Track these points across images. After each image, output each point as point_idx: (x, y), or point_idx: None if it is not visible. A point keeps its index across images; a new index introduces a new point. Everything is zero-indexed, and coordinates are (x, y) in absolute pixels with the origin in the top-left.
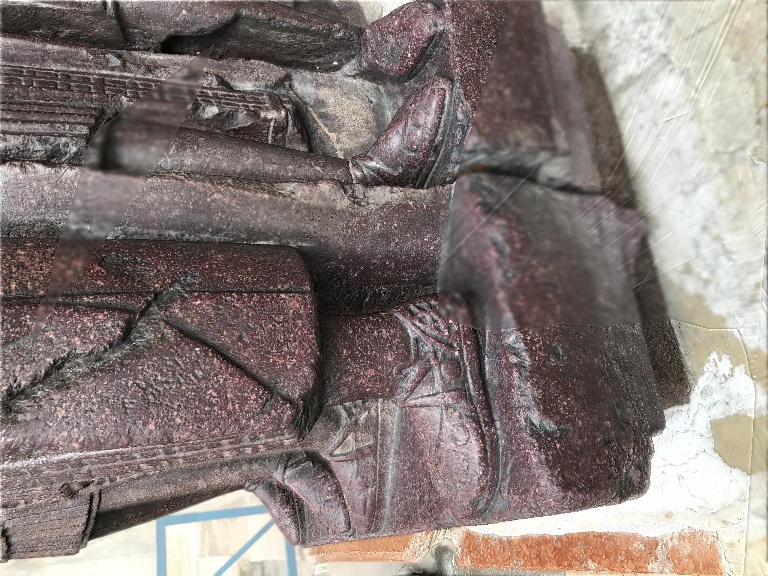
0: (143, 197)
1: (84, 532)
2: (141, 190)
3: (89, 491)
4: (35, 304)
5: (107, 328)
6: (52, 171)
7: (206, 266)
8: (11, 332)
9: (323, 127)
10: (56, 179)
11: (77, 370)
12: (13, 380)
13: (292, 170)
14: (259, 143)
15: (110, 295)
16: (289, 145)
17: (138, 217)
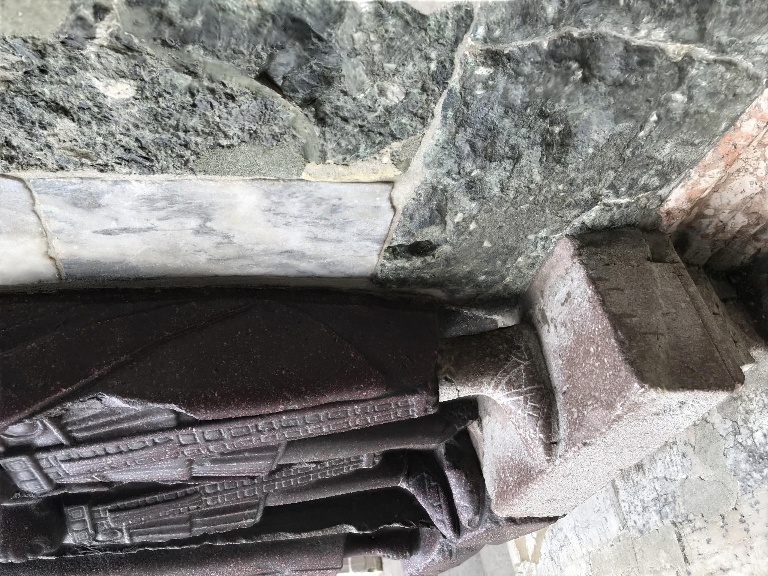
0: None
1: None
2: None
3: None
4: None
5: None
6: (239, 543)
7: None
8: None
9: None
10: None
11: None
12: None
13: None
14: (348, 485)
15: (262, 575)
16: None
17: None
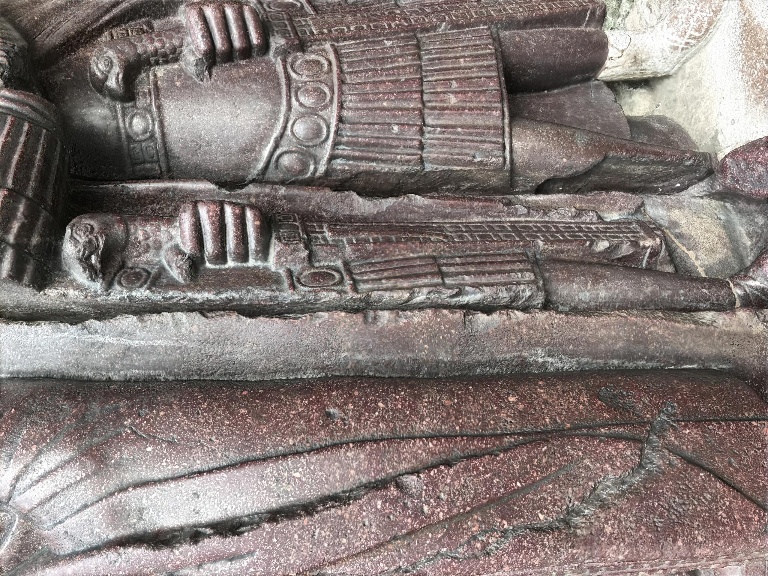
0: (595, 333)
1: None
2: (594, 327)
3: None
4: (571, 436)
5: (628, 456)
6: (529, 316)
7: (679, 397)
8: (561, 460)
9: (681, 246)
10: (532, 323)
11: (610, 492)
12: (568, 501)
13: (684, 294)
14: (650, 271)
15: (619, 426)
16: (660, 267)
17: (590, 350)
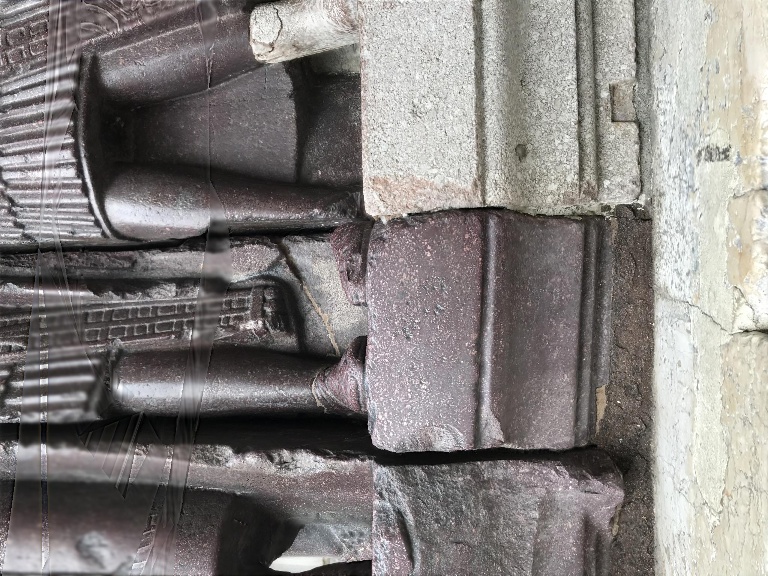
0: None
1: None
2: None
3: None
4: None
5: None
6: None
7: None
8: None
9: (316, 307)
10: None
11: None
12: None
13: (257, 396)
14: (231, 368)
15: None
16: (277, 339)
17: None
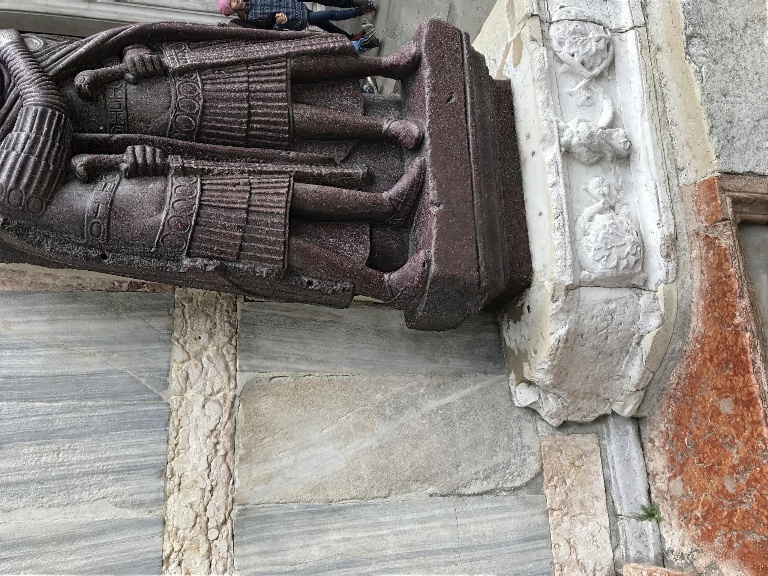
0: None
1: (287, 197)
2: None
3: (289, 170)
4: None
5: None
6: None
7: None
8: None
9: None
10: None
11: None
12: None
13: None
14: None
15: None
16: None
17: None
